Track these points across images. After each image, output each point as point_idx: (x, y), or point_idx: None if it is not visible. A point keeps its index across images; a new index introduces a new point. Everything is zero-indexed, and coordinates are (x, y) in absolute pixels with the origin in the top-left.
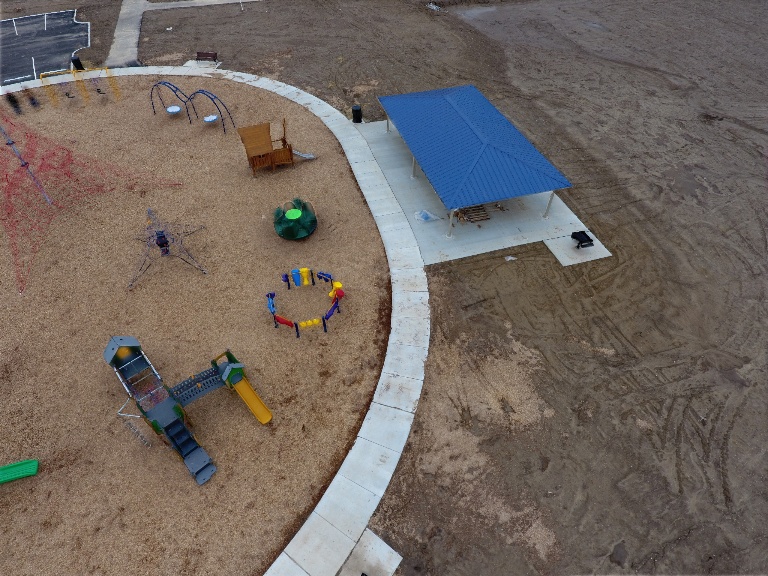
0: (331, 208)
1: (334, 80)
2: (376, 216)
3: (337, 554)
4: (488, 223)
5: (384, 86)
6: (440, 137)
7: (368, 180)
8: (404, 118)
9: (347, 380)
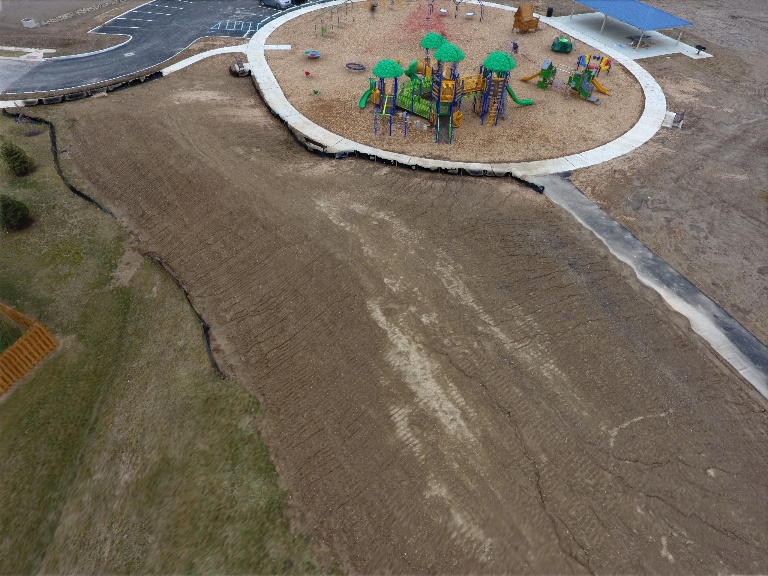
0: None
1: (517, 0)
2: (595, 47)
3: (661, 115)
4: (651, 48)
5: (549, 3)
6: (622, 8)
7: (578, 36)
8: (594, 4)
9: None
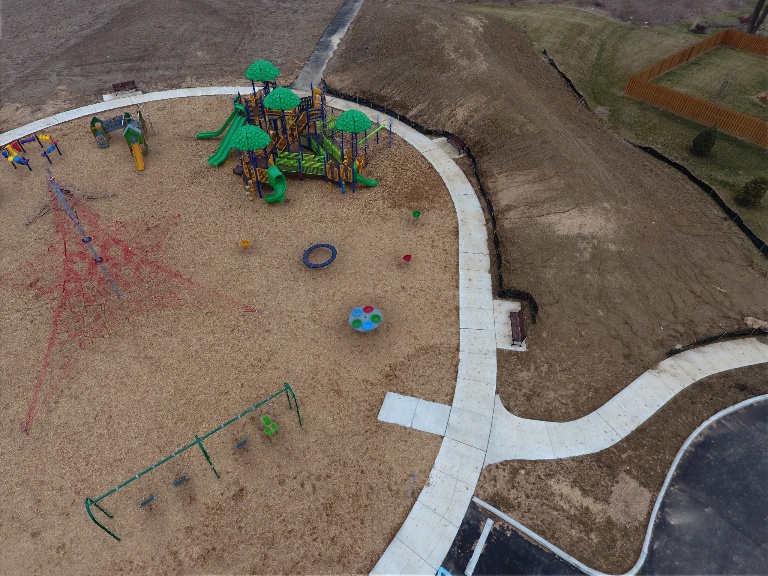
0: None
1: None
2: None
3: None
4: None
5: None
6: None
7: None
8: None
9: (60, 130)
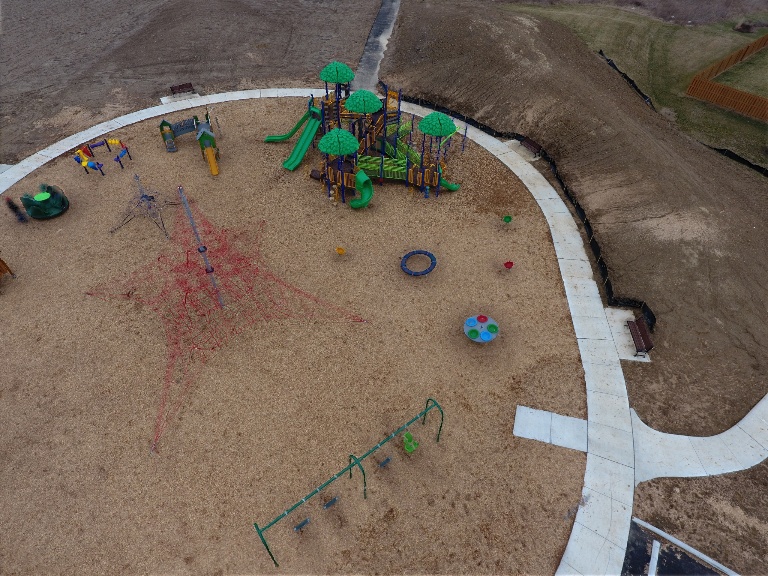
0: (3, 221)
1: None
2: None
3: None
4: None
5: None
6: None
7: None
8: None
9: (124, 134)
